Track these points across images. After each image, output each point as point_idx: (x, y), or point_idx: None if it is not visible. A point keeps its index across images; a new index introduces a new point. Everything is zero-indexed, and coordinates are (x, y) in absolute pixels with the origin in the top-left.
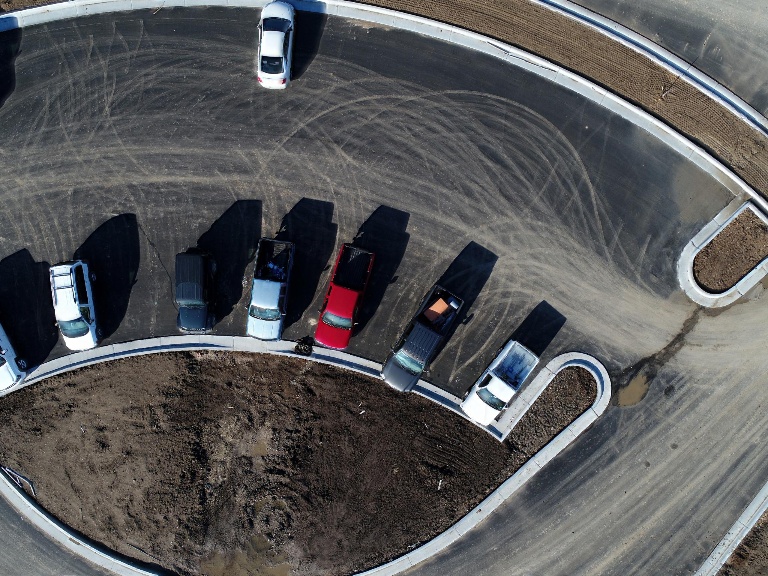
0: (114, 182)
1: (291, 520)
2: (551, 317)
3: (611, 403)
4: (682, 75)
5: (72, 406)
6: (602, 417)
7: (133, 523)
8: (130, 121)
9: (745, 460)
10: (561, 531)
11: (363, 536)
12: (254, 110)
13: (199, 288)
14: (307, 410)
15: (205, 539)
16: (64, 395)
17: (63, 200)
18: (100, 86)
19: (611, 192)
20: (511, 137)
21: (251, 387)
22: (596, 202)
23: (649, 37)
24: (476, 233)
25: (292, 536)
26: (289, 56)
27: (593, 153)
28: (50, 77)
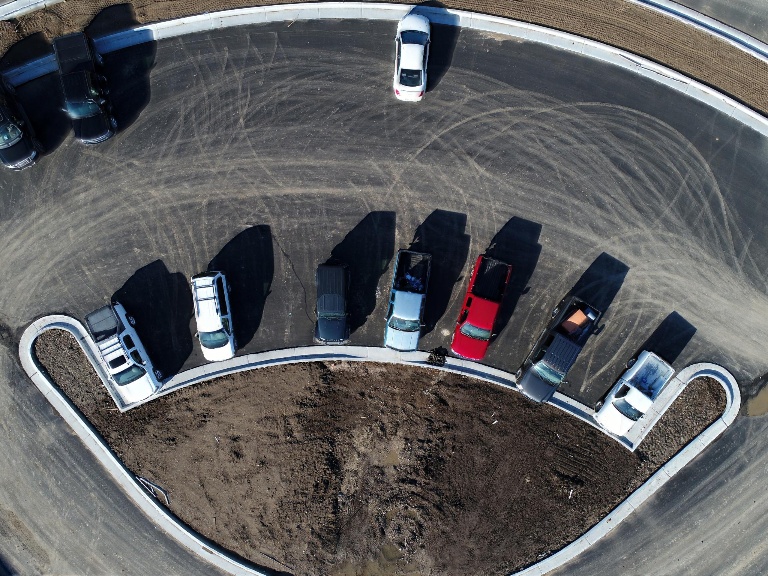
0: (248, 193)
1: (423, 529)
2: (681, 328)
3: (740, 413)
4: None
5: (206, 416)
6: (731, 427)
7: (266, 532)
8: (264, 133)
9: None
10: (690, 540)
11: (494, 545)
12: (388, 122)
13: (341, 300)
14: (439, 420)
15: (337, 548)
16: (198, 405)
17: (198, 211)
18: (235, 98)
19: (741, 203)
20: (642, 149)
21: (384, 397)
22: (726, 213)
23: None
24: (607, 244)
25: (423, 545)
26: None
27: (723, 164)
28: (185, 89)
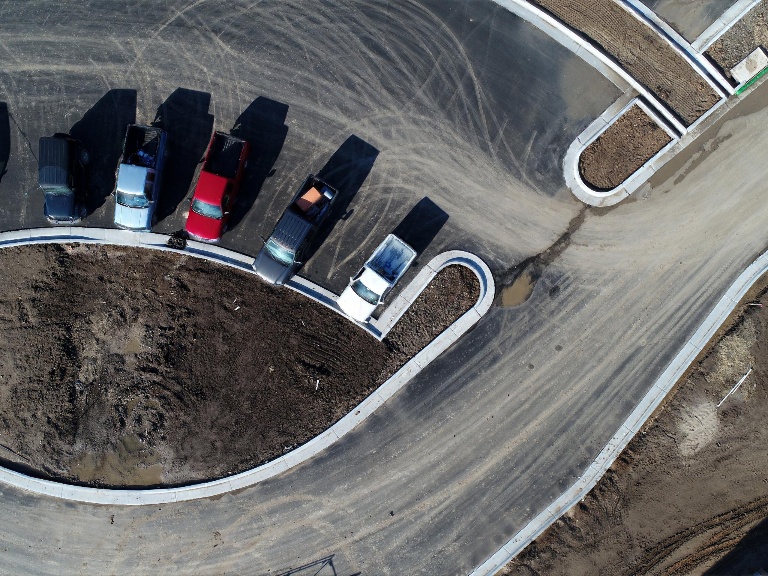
0: None
1: (164, 420)
2: (433, 214)
3: (495, 303)
4: None
5: None
6: (485, 318)
7: (0, 421)
8: (2, 7)
9: (631, 363)
10: (442, 434)
11: (238, 437)
12: None
13: (63, 172)
14: (181, 306)
15: (75, 438)
16: None
17: None
18: None
19: (496, 87)
20: (393, 29)
21: (124, 282)
22: (480, 97)
23: None
24: (357, 126)
25: (165, 436)
26: None
27: (478, 46)
28: None
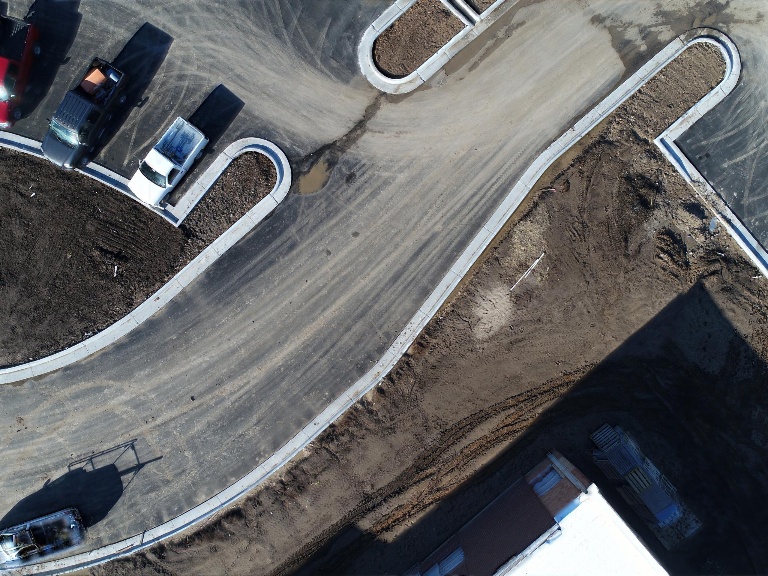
0: None
1: None
2: (229, 101)
3: (292, 191)
4: None
5: None
6: (283, 205)
7: None
8: None
9: (427, 249)
10: (241, 320)
11: (38, 323)
12: None
13: None
14: None
15: None
16: None
17: None
18: None
19: None
20: None
21: None
22: None
23: None
24: (151, 14)
25: None
26: None
27: None
28: None
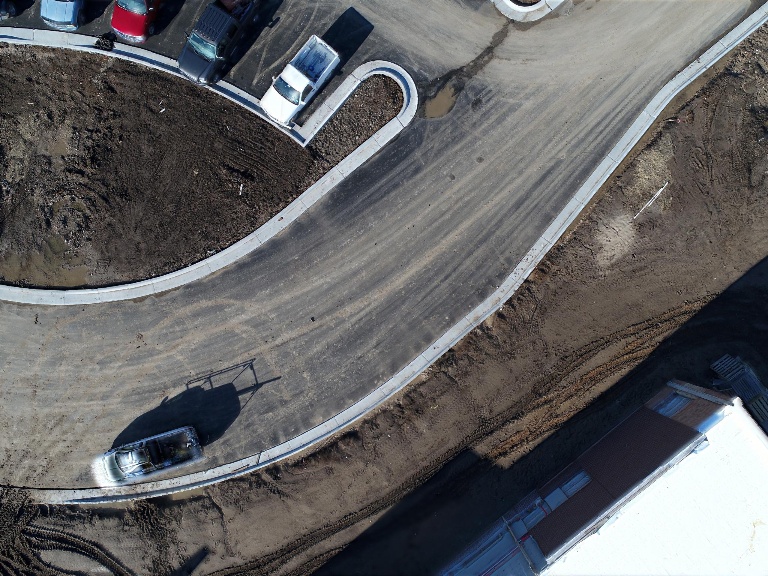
0: None
1: (89, 221)
2: (358, 24)
3: (418, 115)
4: None
5: None
6: (408, 128)
7: None
8: None
9: (551, 176)
10: (364, 242)
11: (162, 239)
12: None
13: None
14: (108, 109)
15: (1, 238)
16: None
17: None
18: None
19: None
20: None
21: (52, 84)
22: None
23: None
24: None
25: (90, 238)
26: None
27: None
28: None
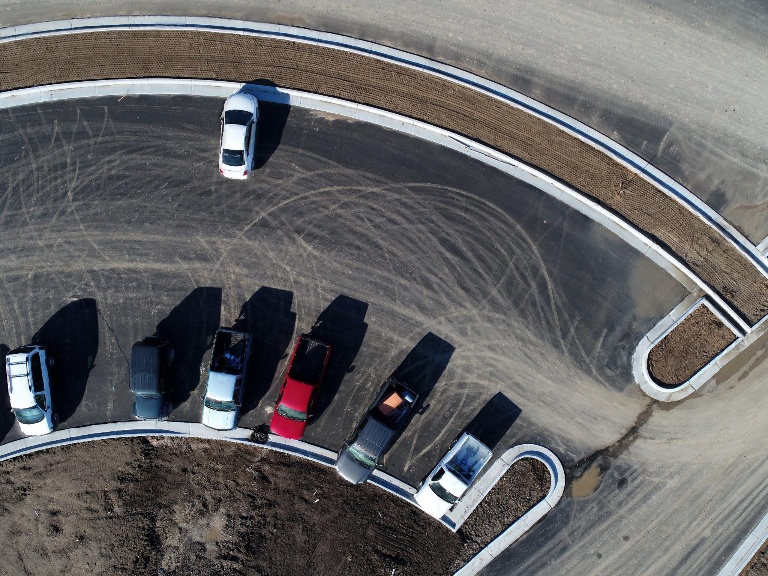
0: (74, 267)
1: None
2: (506, 408)
3: (565, 494)
4: (639, 173)
5: (27, 489)
6: (555, 508)
7: None
8: (92, 206)
9: (696, 553)
10: None
11: None
12: (216, 198)
13: (154, 379)
14: (262, 497)
15: None
16: (19, 478)
17: (23, 283)
18: (63, 171)
19: (568, 286)
20: (470, 230)
21: (207, 473)
22: (553, 295)
23: (608, 135)
24: (434, 324)
25: None
26: (251, 148)
27: (551, 247)
28: (13, 161)
